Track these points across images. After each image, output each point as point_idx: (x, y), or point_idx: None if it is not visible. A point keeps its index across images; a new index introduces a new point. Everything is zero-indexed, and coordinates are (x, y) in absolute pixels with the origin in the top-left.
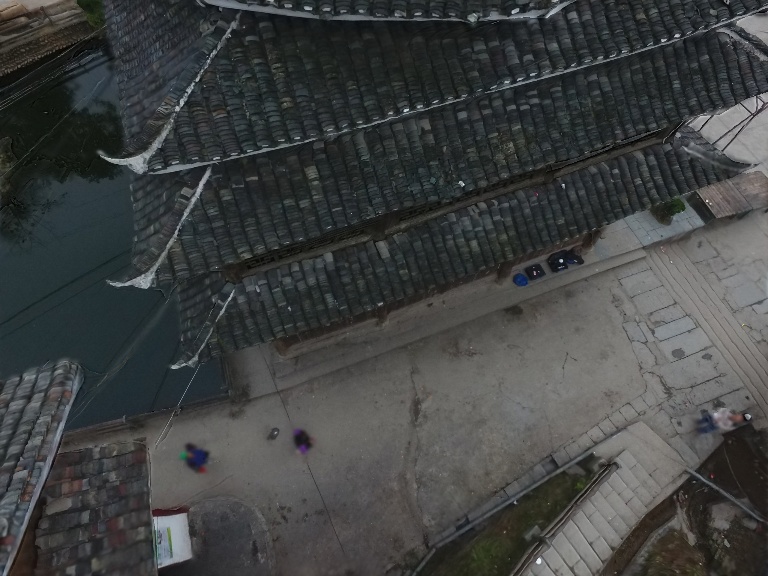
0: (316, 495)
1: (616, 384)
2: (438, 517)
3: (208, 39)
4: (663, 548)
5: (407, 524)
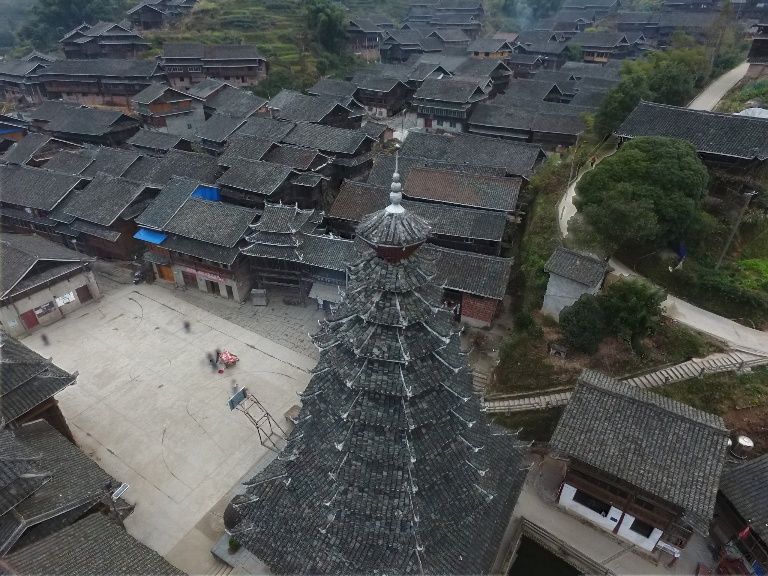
0: None
1: None
2: None
3: None
4: None
5: None
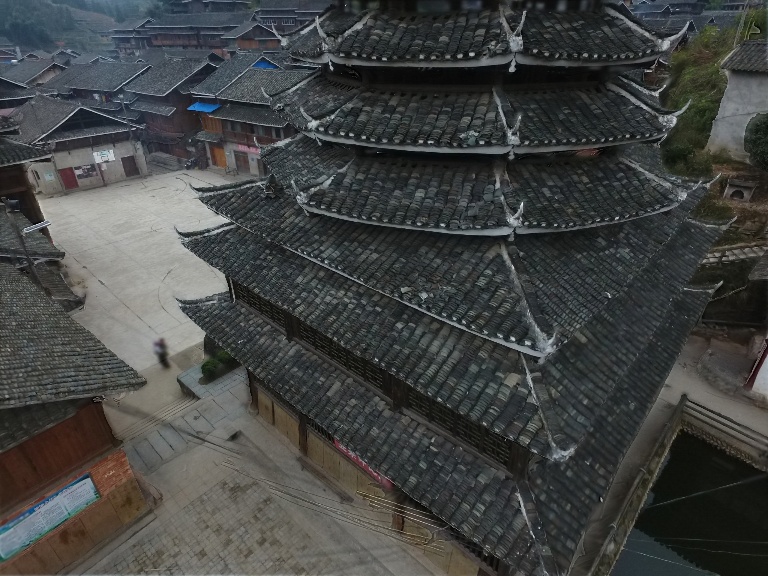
0: None
1: None
2: None
3: None
4: None
5: None
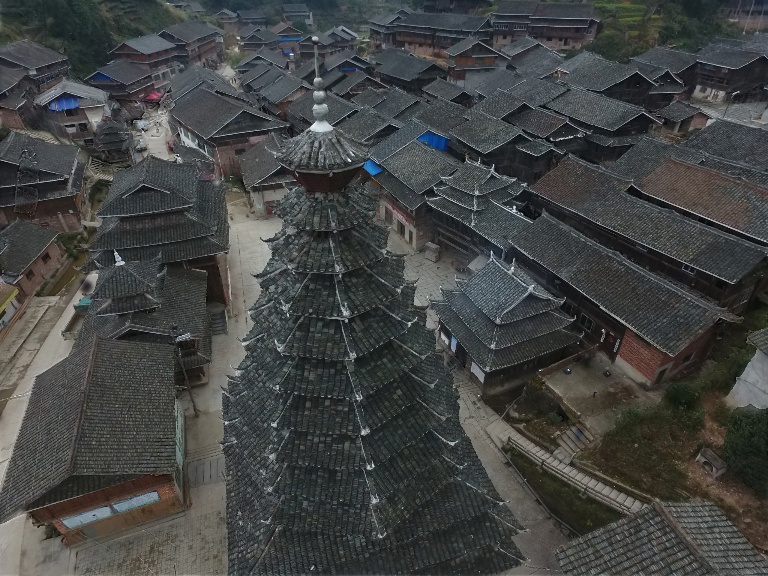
0: (542, 570)
1: (470, 434)
2: (538, 513)
3: (459, 476)
4: (532, 431)
5: (544, 527)
